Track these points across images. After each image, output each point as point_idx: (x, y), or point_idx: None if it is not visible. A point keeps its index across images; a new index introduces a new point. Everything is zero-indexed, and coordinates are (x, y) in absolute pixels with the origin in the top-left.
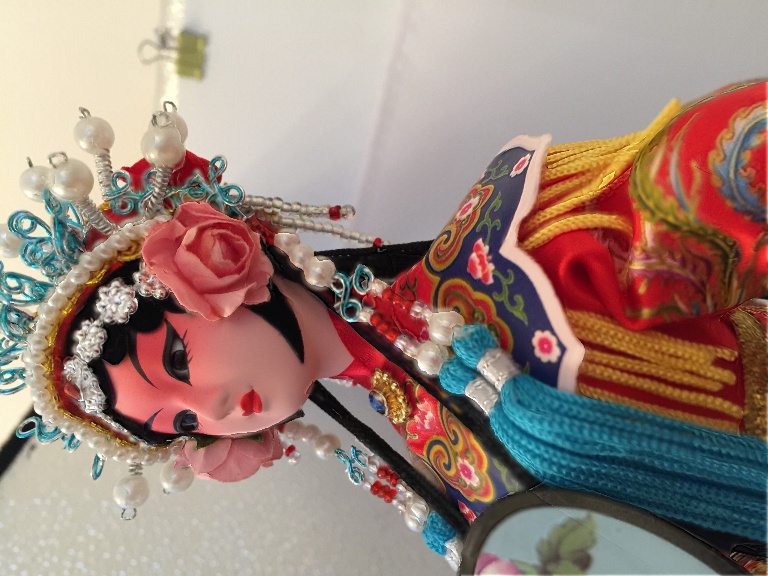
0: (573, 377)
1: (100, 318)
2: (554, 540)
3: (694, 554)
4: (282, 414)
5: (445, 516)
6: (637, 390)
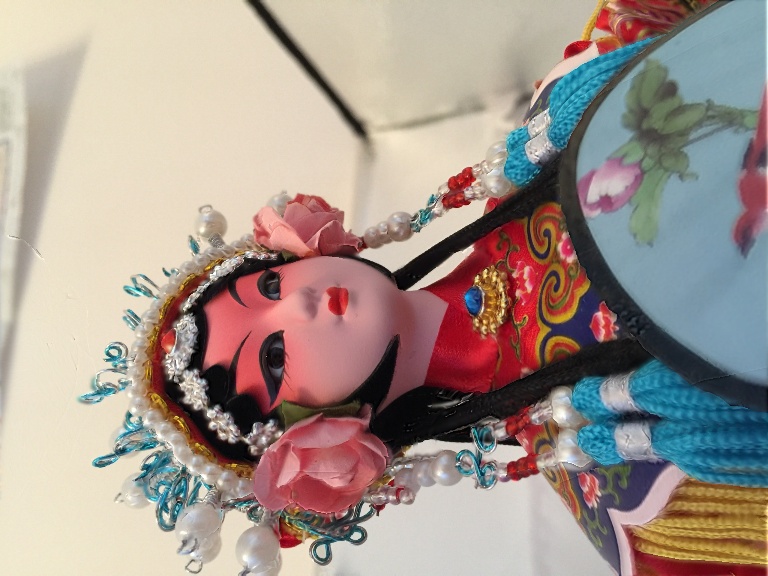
0: None
1: (210, 281)
2: (634, 104)
3: None
4: (371, 317)
5: (588, 367)
6: None
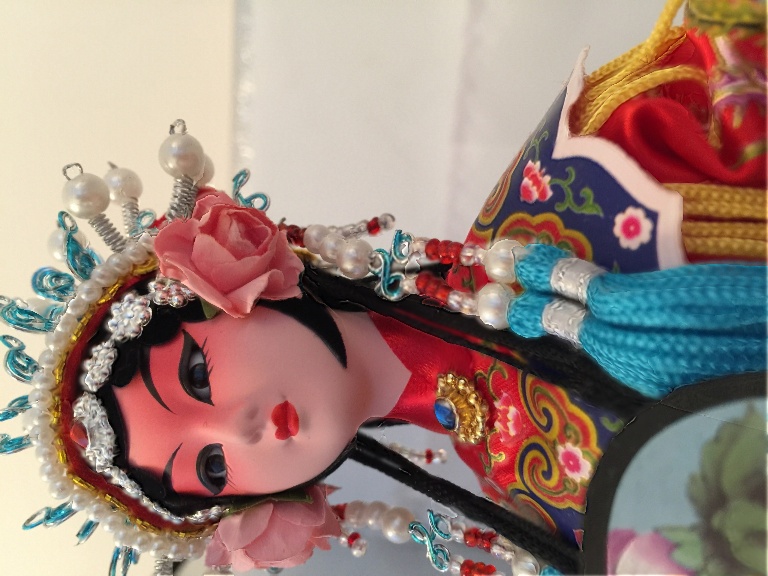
0: (677, 245)
1: (111, 338)
2: (712, 471)
3: None
4: (326, 437)
5: (561, 565)
6: None
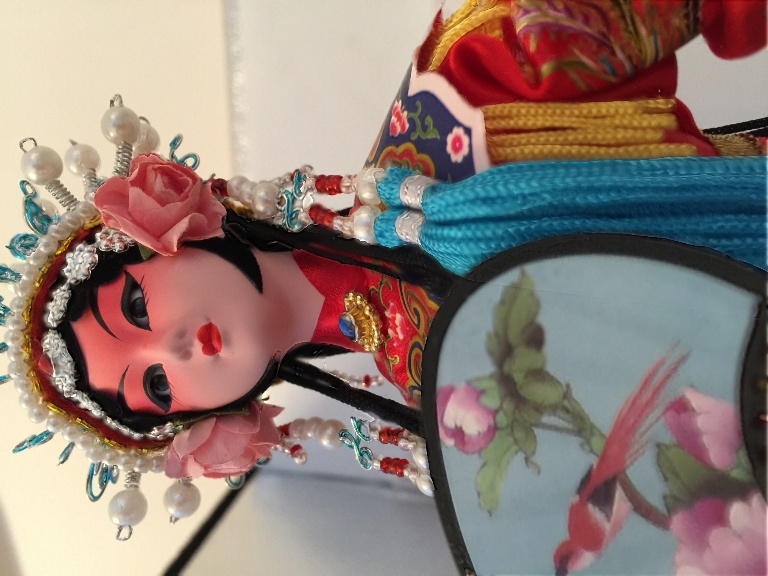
0: (484, 153)
1: (67, 282)
2: (500, 327)
3: (643, 255)
4: (248, 352)
5: None
6: (566, 159)
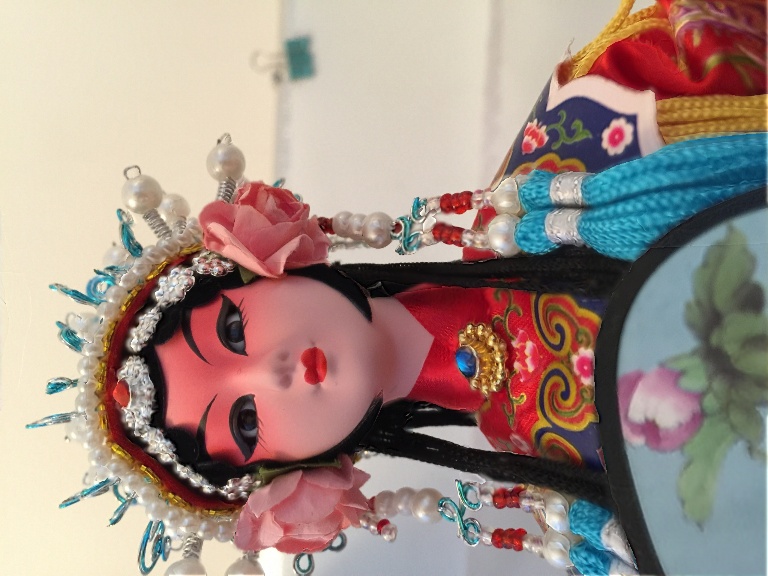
0: (655, 135)
1: (157, 305)
2: (704, 294)
3: None
4: (353, 384)
5: (589, 493)
6: None
